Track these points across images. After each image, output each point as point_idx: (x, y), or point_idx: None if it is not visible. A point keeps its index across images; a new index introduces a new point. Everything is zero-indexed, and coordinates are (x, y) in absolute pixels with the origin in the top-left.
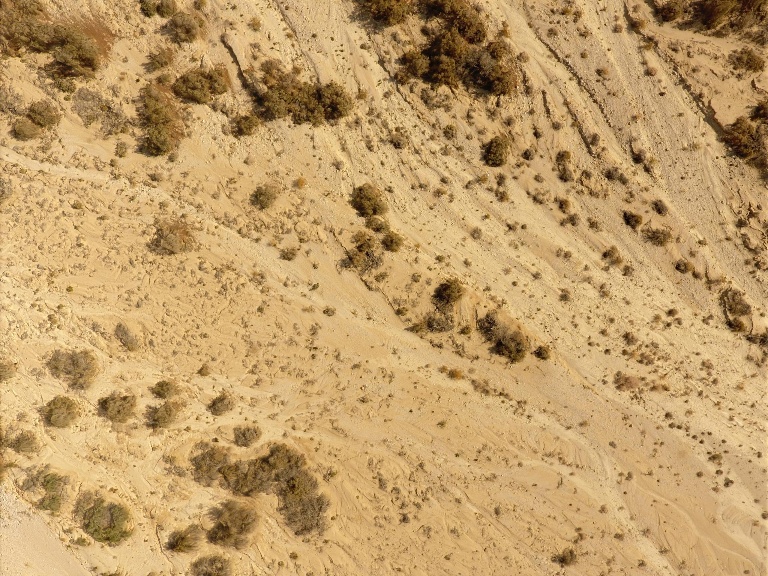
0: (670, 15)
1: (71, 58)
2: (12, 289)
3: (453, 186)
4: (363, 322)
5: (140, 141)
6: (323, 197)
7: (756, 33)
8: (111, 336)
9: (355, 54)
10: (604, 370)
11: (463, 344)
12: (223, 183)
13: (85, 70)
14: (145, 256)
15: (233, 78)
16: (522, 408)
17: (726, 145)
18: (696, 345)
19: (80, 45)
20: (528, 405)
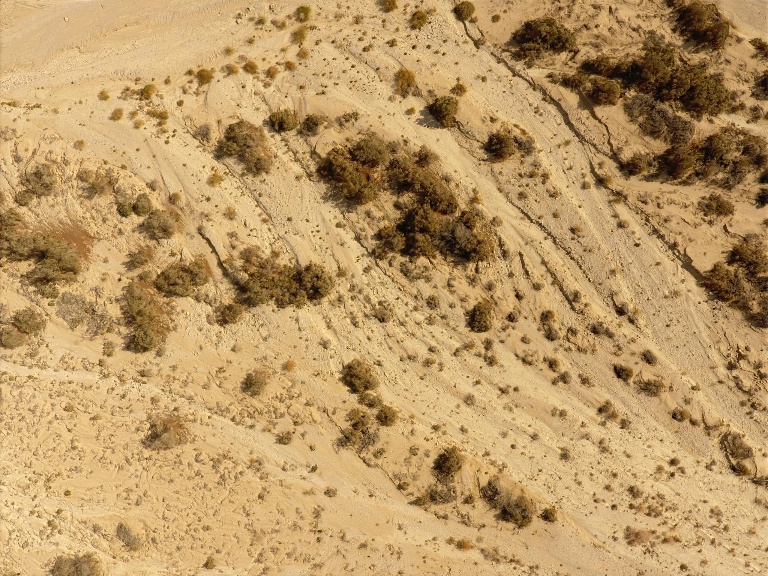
0: (636, 170)
1: (52, 271)
2: (10, 497)
3: (441, 355)
4: (365, 500)
5: (127, 339)
6: (313, 377)
7: (722, 180)
8: (113, 537)
9: (331, 233)
10: (613, 526)
11: (468, 513)
12: (212, 373)
13: (67, 275)
14: (141, 453)
15: (213, 268)
16: (535, 573)
17: (707, 290)
18: (702, 492)
19: (60, 257)
20: (540, 569)
